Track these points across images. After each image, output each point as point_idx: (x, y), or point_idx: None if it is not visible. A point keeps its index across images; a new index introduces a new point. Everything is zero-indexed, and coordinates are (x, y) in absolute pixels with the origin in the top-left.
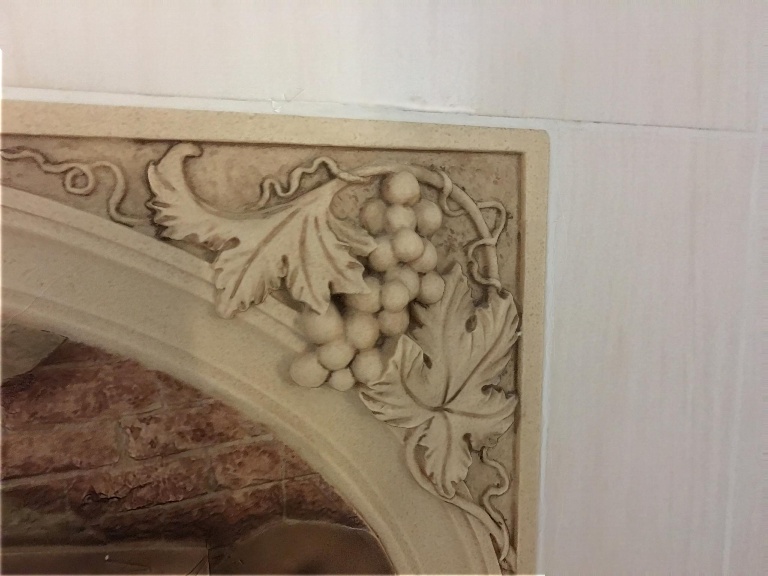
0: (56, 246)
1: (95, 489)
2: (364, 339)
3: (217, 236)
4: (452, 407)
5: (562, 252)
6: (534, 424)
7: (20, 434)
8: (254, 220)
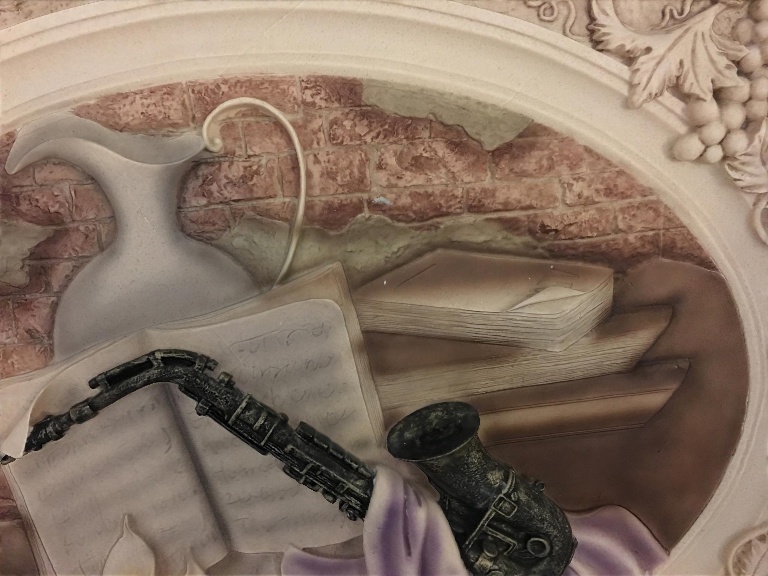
0: (532, 57)
1: (544, 223)
2: (736, 120)
3: (636, 46)
4: None
5: None
6: None
7: (502, 183)
8: (660, 35)
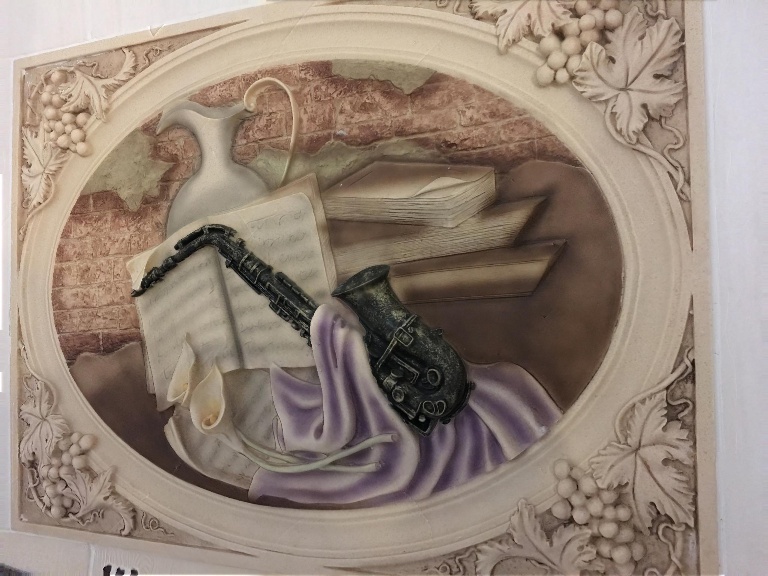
0: (433, 31)
1: (446, 139)
2: (570, 47)
3: (497, 11)
4: (632, 87)
5: None
6: (699, 100)
7: (418, 115)
8: (515, 1)
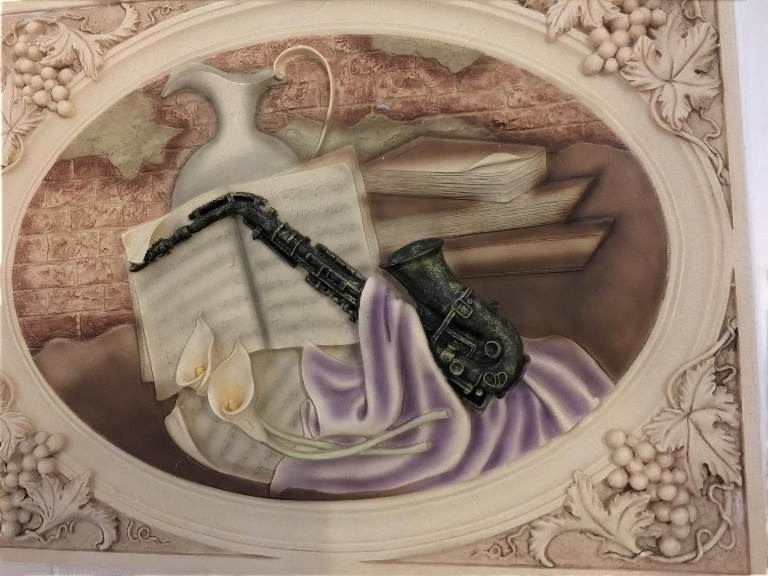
0: (480, 15)
1: (494, 118)
2: (621, 39)
3: (548, 1)
4: (676, 79)
5: (744, 1)
6: (734, 95)
7: (464, 94)
8: None
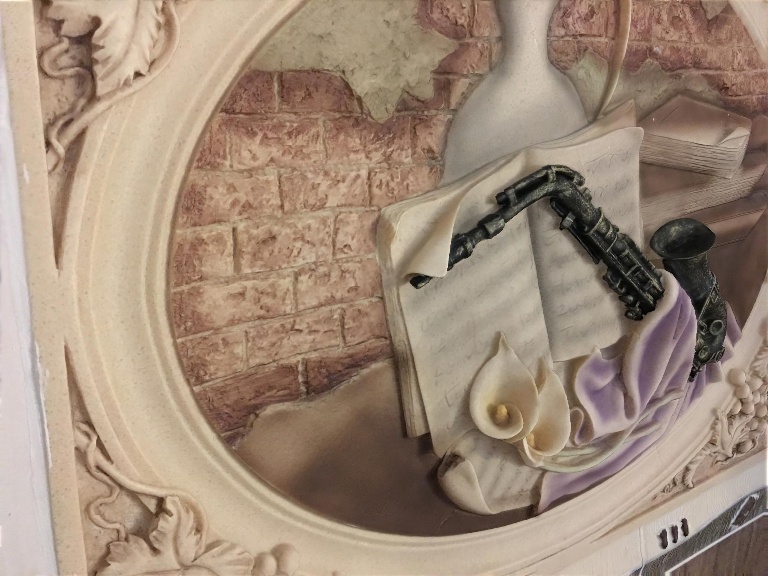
0: None
1: (724, 81)
2: None
3: None
4: None
5: None
6: None
7: None
8: None
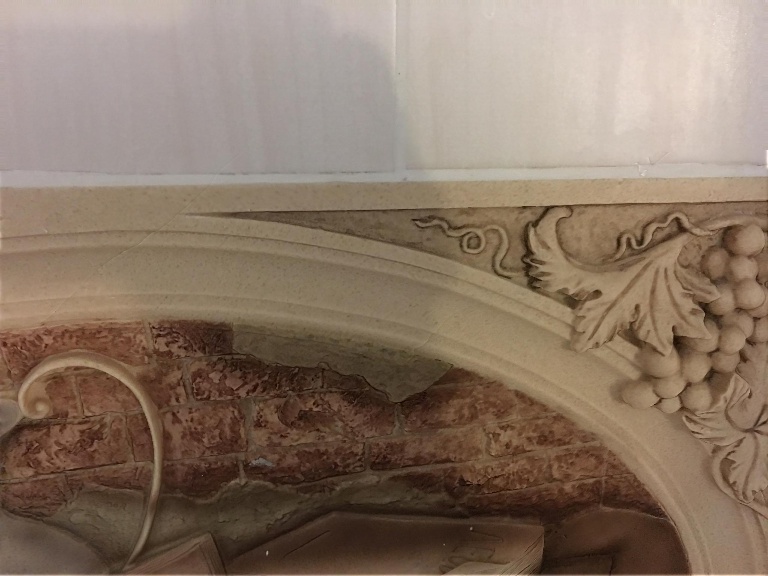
0: (451, 295)
1: (464, 477)
2: (699, 376)
3: (583, 289)
4: (763, 430)
5: None
6: None
7: (413, 435)
8: (613, 273)
